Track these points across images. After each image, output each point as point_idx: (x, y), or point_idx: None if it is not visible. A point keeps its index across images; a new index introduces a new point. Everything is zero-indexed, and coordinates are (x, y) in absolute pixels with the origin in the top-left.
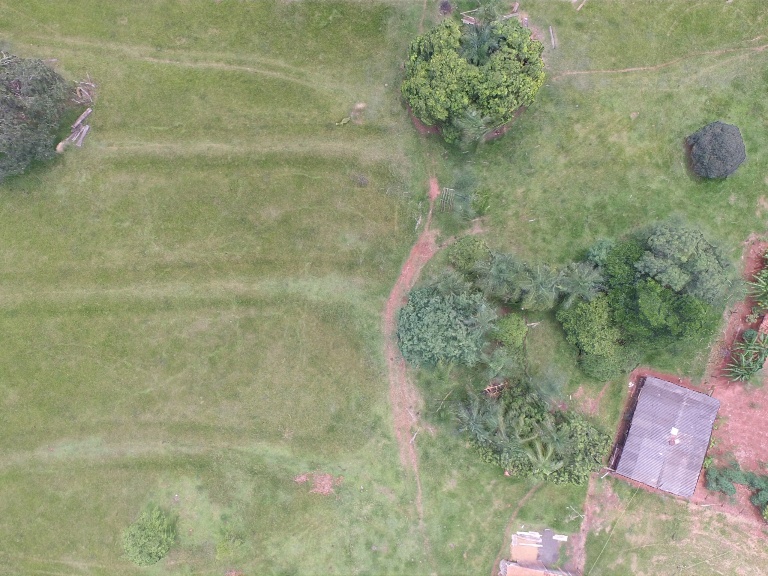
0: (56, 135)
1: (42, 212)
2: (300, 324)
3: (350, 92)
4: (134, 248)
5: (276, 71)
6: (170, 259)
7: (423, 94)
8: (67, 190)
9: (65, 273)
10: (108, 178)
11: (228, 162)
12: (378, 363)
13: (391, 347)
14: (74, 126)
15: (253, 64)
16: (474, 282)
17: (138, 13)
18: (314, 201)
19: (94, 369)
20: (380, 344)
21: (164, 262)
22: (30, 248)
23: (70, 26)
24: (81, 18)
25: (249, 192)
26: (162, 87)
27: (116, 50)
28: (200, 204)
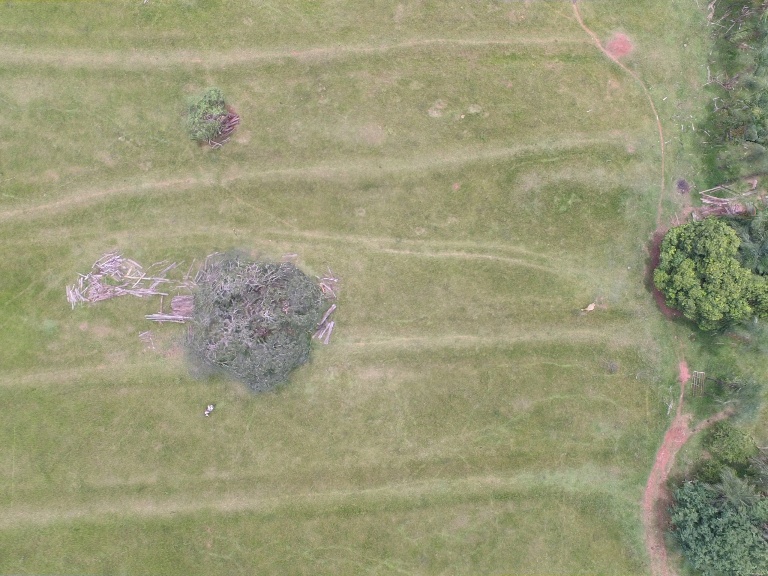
0: (309, 339)
1: (292, 413)
2: (560, 517)
3: (593, 276)
4: (387, 446)
5: (518, 258)
6: (425, 456)
7: (694, 295)
8: (316, 389)
9: (319, 474)
10: (357, 375)
11: (476, 353)
12: (639, 553)
13: (651, 536)
14: (320, 324)
15: (495, 252)
16: (756, 485)
17: (376, 204)
18: (565, 390)
19: (356, 573)
20: (640, 533)
21: (419, 459)
22: (282, 450)
23: (308, 220)
24: (318, 211)
25: (500, 384)
26: (404, 279)
27: (356, 243)
28: (452, 398)
